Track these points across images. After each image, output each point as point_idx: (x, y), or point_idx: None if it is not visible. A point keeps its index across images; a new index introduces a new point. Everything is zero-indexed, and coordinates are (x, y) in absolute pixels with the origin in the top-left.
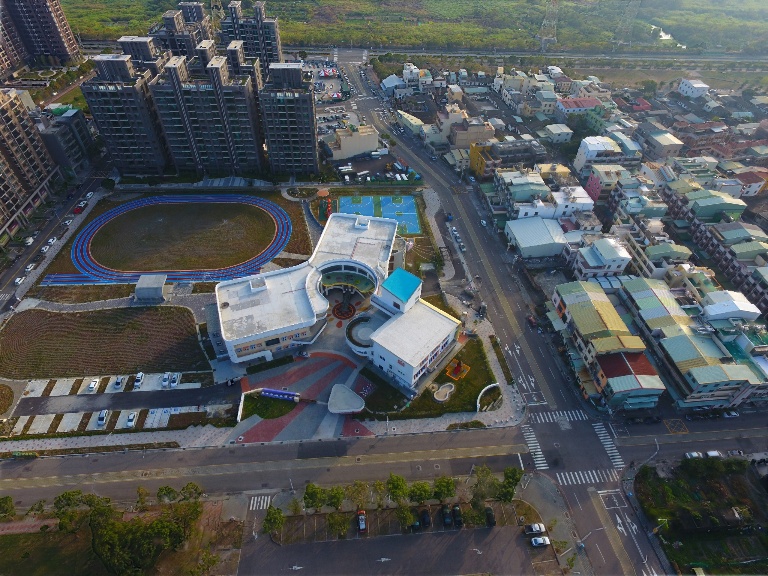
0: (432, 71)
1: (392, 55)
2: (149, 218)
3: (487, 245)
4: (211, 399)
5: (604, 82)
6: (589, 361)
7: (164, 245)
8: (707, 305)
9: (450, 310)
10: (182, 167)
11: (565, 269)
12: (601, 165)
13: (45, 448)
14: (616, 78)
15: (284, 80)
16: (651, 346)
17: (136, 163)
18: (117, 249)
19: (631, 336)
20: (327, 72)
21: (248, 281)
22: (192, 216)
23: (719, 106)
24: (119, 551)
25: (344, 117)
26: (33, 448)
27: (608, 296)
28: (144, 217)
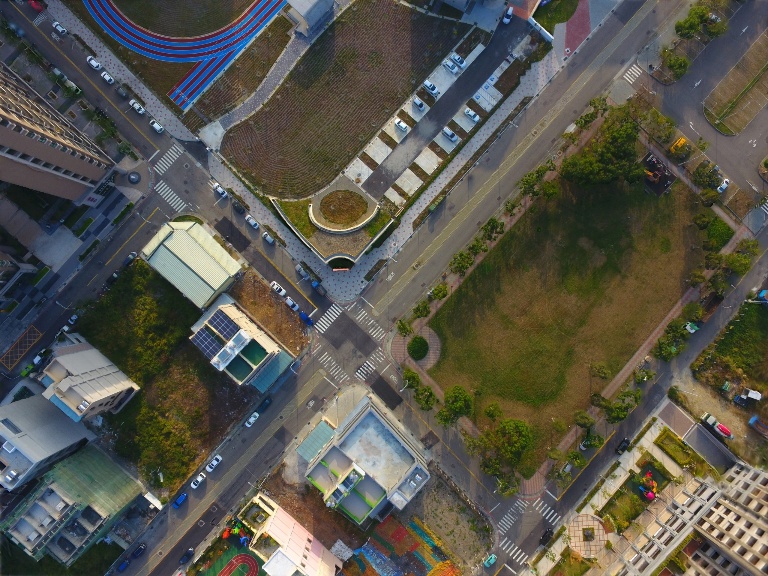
0: None
1: None
2: None
3: None
4: (507, 46)
5: None
6: None
7: None
8: None
9: None
10: None
11: None
12: None
13: (441, 188)
14: None
15: None
16: None
17: None
18: (179, 5)
19: None
20: None
21: None
22: None
23: None
24: (613, 166)
25: None
26: (432, 197)
27: None
28: None
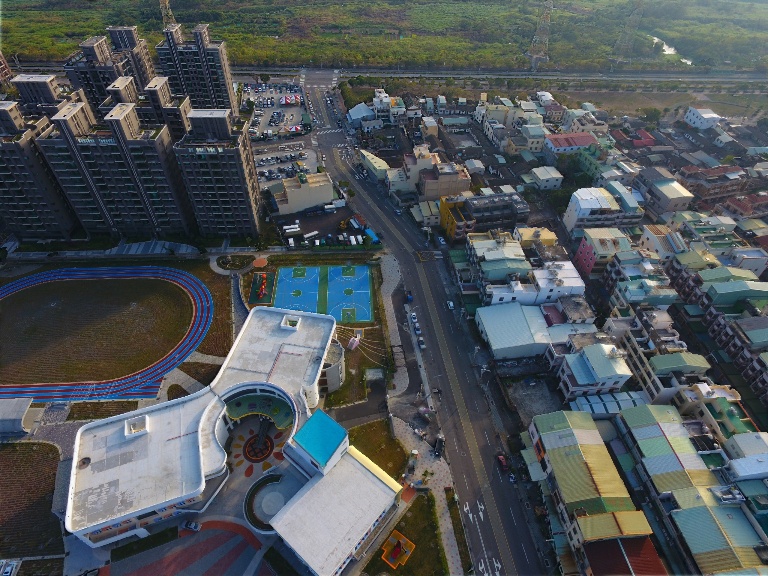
0: (406, 99)
1: (364, 78)
2: (40, 302)
3: (453, 338)
4: None
5: (601, 109)
6: (574, 544)
7: (49, 343)
8: (733, 452)
9: (397, 445)
10: (93, 230)
11: (548, 376)
12: (595, 229)
13: None
14: (614, 103)
15: (207, 130)
16: (659, 514)
17: (35, 227)
18: None
19: (632, 512)
20: (289, 99)
21: (125, 419)
22: (94, 298)
23: (732, 141)
24: None
25: (300, 157)
26: None
27: (602, 424)
28: (34, 300)
